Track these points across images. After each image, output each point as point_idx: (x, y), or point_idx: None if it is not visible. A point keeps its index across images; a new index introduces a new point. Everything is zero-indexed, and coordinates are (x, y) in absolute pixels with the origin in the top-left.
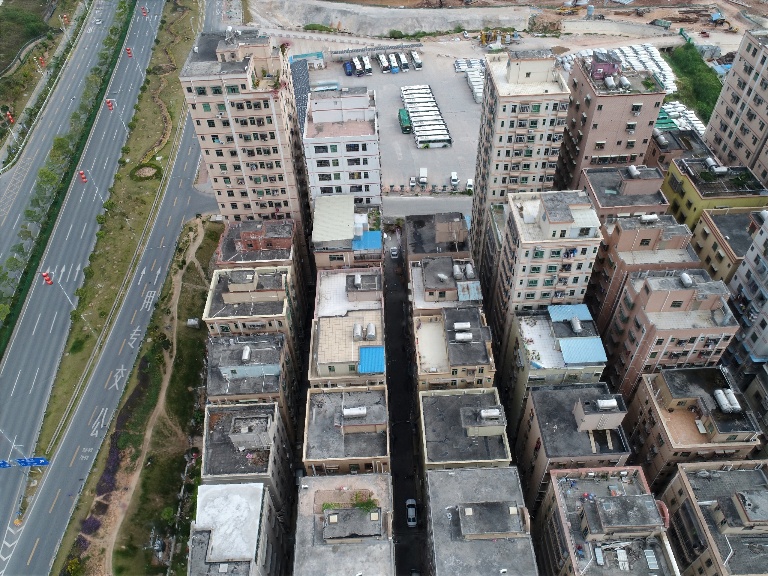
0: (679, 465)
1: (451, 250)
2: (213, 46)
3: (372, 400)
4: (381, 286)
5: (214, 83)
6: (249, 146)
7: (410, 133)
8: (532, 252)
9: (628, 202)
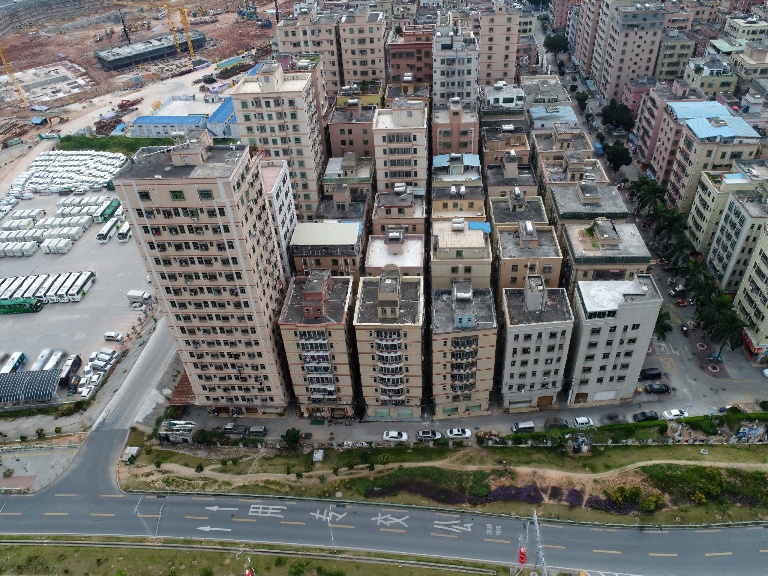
0: (539, 151)
1: (359, 205)
2: (152, 173)
3: (507, 236)
4: (401, 227)
5: (240, 169)
6: (260, 225)
7: (43, 306)
8: (425, 133)
9: (366, 118)
